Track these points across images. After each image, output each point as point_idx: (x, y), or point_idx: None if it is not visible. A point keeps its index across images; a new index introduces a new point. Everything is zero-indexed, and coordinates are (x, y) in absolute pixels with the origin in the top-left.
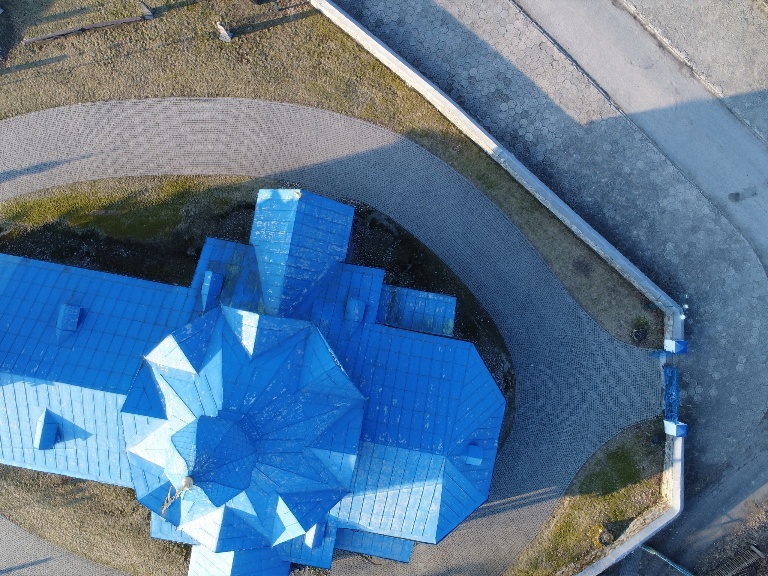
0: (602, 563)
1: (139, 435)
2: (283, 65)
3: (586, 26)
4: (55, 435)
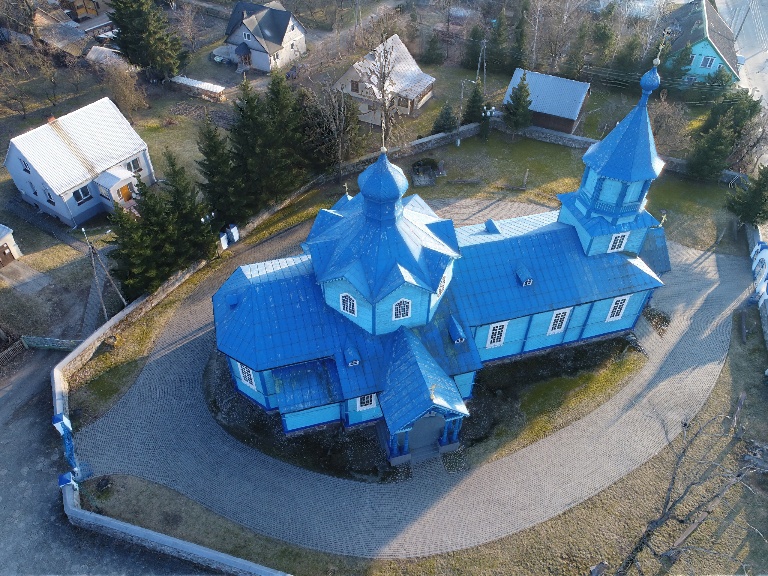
0: (112, 323)
1: None
2: (531, 571)
3: None
4: (488, 229)
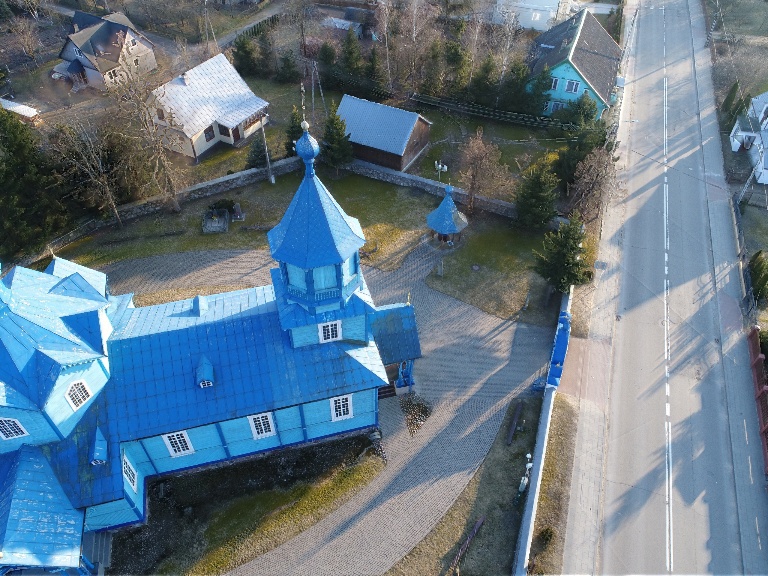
0: None
1: None
2: None
3: None
4: None
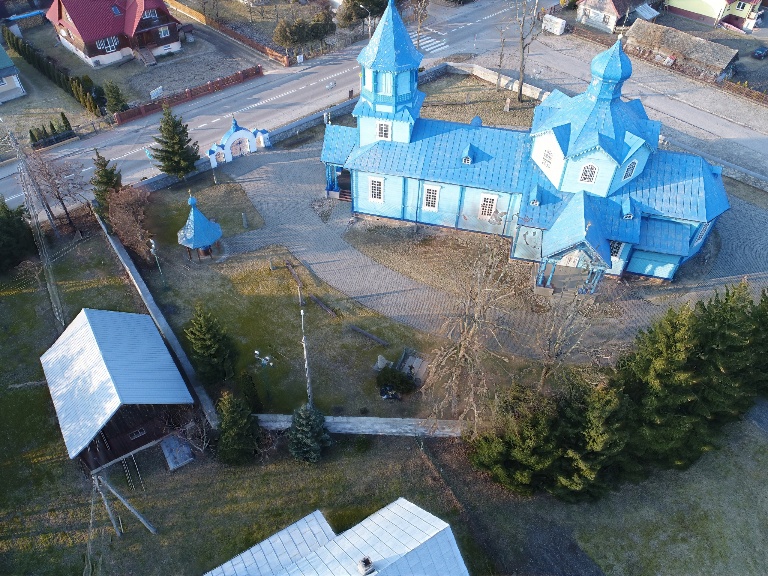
0: None
1: (541, 121)
2: None
3: (688, 114)
4: None
